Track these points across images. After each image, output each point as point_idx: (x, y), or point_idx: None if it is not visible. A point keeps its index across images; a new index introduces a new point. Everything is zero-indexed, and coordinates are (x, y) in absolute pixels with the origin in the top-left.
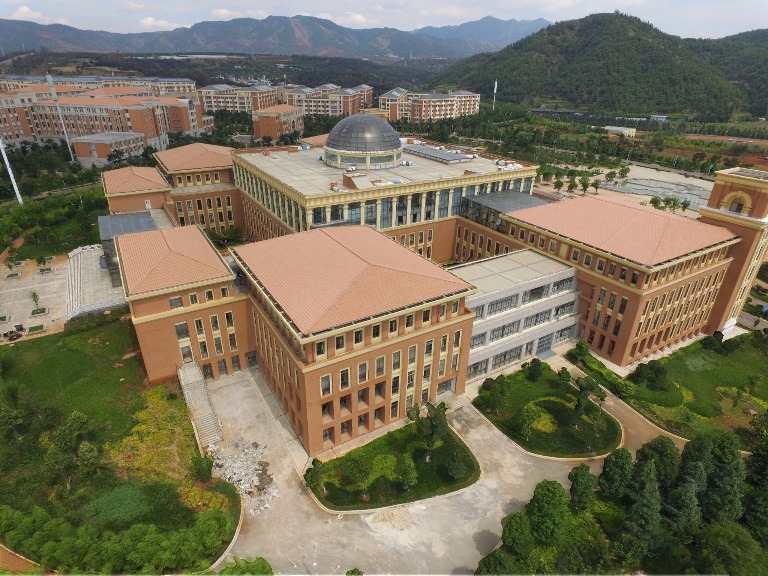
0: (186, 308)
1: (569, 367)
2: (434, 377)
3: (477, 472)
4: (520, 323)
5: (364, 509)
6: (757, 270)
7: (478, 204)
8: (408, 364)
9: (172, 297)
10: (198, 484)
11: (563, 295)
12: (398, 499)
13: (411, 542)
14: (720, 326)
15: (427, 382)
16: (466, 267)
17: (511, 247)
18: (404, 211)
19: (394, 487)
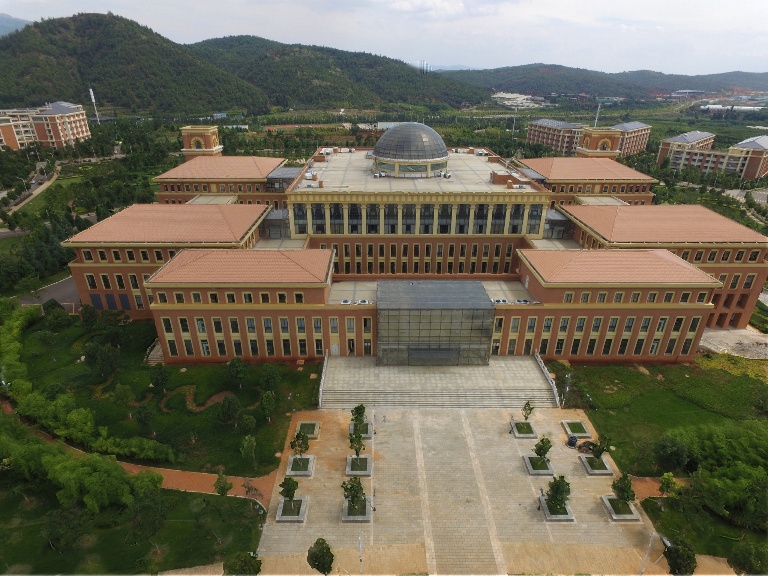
0: None
1: None
2: None
3: None
4: None
5: None
6: None
7: None
8: None
9: None
10: None
11: None
12: None
13: None
14: None
15: None
16: None
17: (558, 200)
18: None
19: (766, 312)
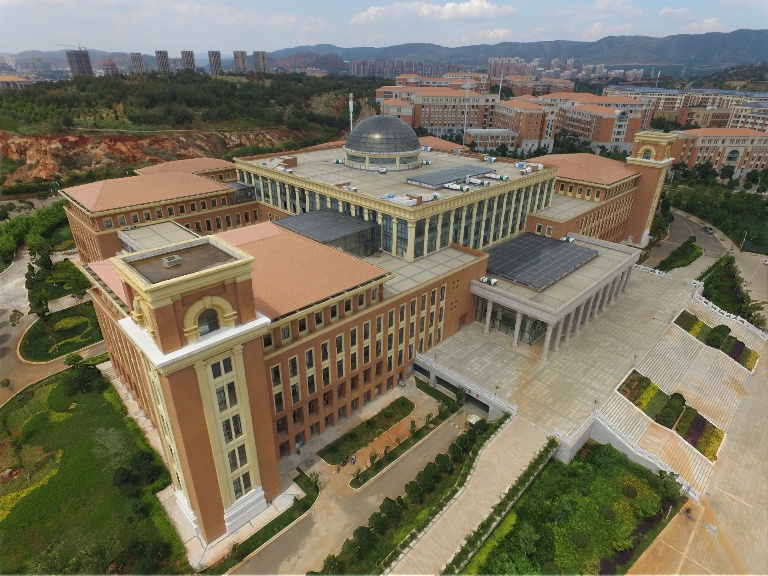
0: None
1: None
2: None
3: None
4: None
5: None
6: None
7: None
8: None
9: None
10: None
11: None
12: None
13: (6, 286)
14: None
15: None
16: (190, 234)
17: None
18: None
19: None
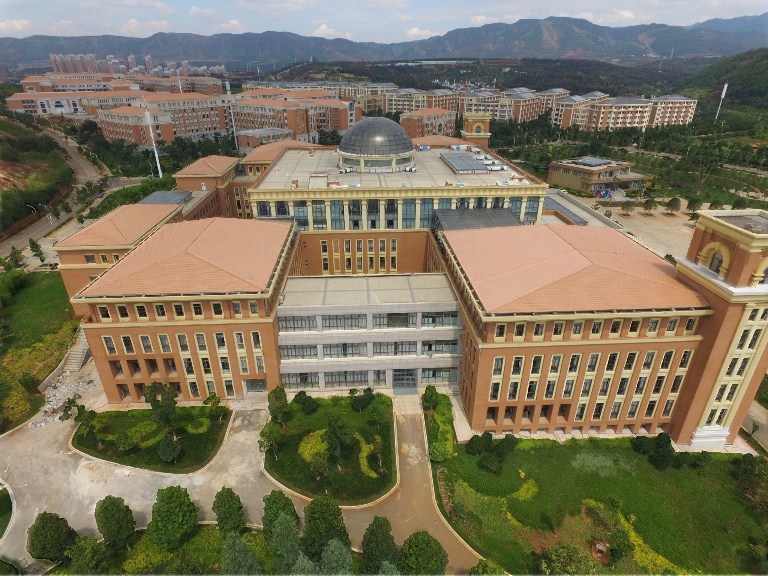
0: (97, 265)
1: (415, 411)
2: (234, 371)
3: (200, 466)
4: (367, 347)
5: (90, 455)
6: (763, 365)
7: (438, 218)
8: (199, 350)
9: (87, 254)
10: (26, 393)
11: (440, 330)
12: (118, 458)
13: (86, 493)
14: (686, 430)
15: (228, 374)
16: (351, 278)
17: (441, 269)
18: (360, 216)
19: None
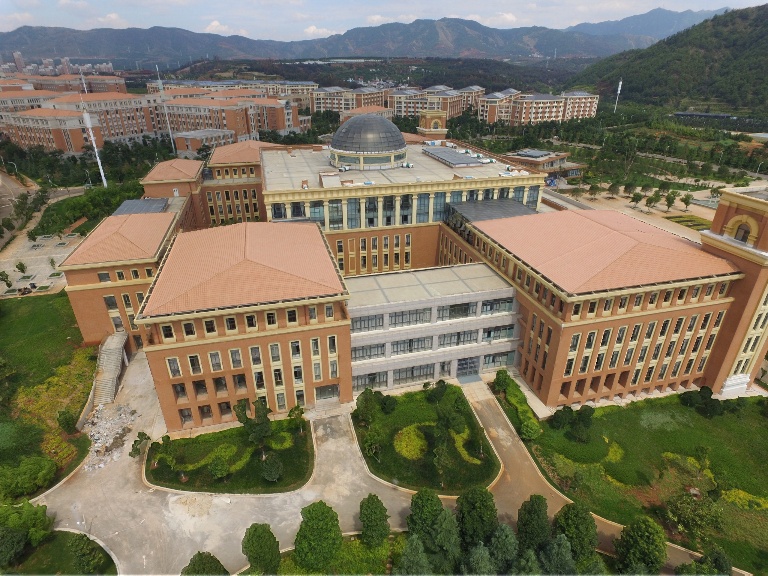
0: (112, 283)
1: (486, 396)
2: (307, 379)
3: (304, 481)
4: (433, 340)
5: (175, 489)
6: None
7: (456, 211)
8: (272, 361)
9: (100, 272)
10: (64, 435)
11: (498, 316)
12: (210, 487)
13: (192, 529)
14: (719, 381)
15: (300, 383)
16: (397, 274)
17: (473, 259)
18: (375, 213)
19: None
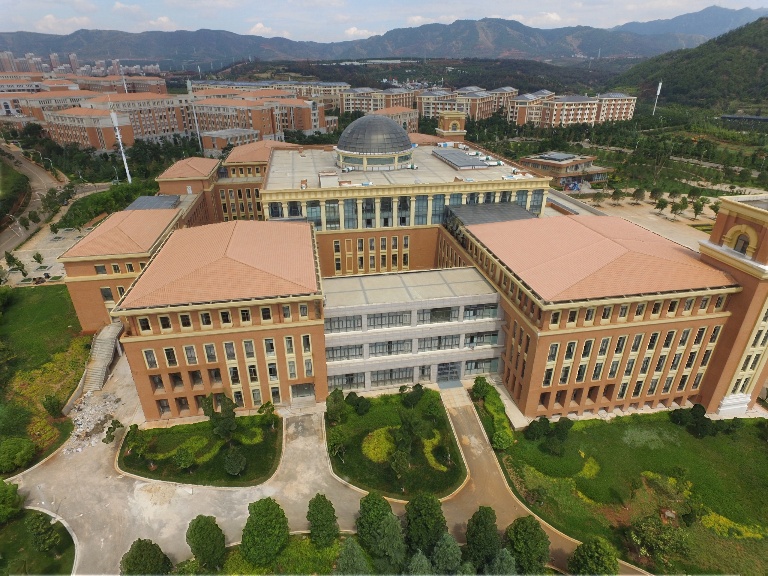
0: (108, 275)
1: (464, 403)
2: (282, 377)
3: (266, 477)
4: (412, 343)
5: (143, 476)
6: None
7: (453, 214)
8: (246, 357)
9: (97, 264)
10: (50, 418)
11: (481, 322)
12: (176, 477)
13: (152, 517)
14: (715, 400)
15: (276, 380)
16: (383, 276)
17: (466, 263)
18: (373, 214)
19: None
